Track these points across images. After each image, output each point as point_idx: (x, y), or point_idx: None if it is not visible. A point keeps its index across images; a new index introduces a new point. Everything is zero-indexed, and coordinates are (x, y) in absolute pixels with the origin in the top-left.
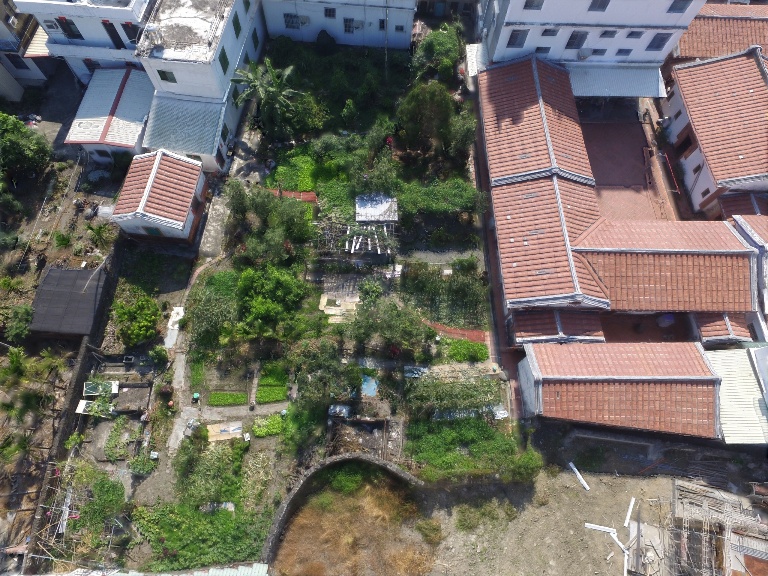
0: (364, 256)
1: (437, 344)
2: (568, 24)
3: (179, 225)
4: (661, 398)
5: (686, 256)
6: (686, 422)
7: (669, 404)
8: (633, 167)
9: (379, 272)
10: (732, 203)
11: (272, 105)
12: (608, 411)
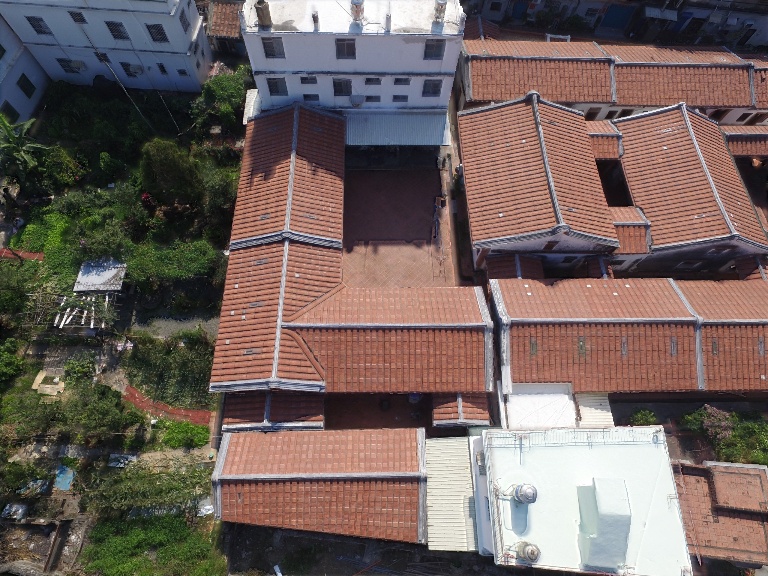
0: (78, 330)
1: (153, 428)
2: (323, 72)
3: None
4: (358, 498)
5: (414, 331)
6: (385, 525)
7: (367, 505)
8: (420, 219)
9: (110, 344)
10: (497, 264)
11: (13, 161)
12: (296, 514)
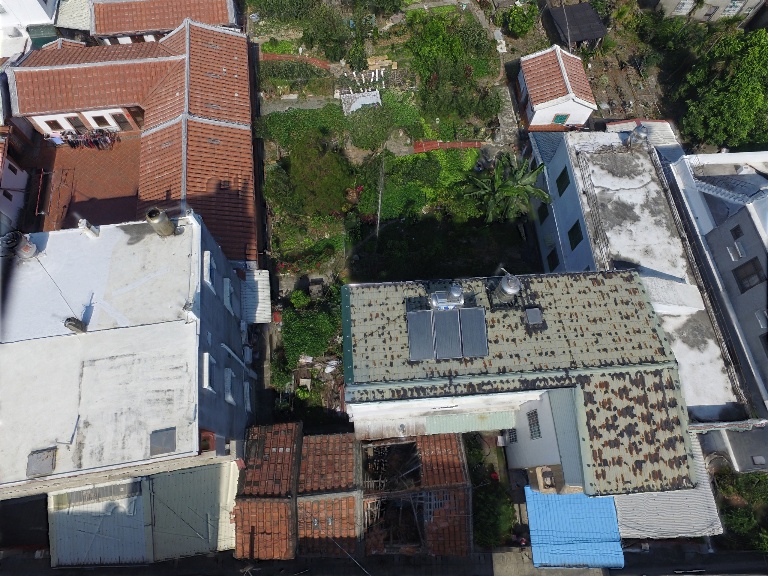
0: None
1: None
2: None
3: (524, 58)
4: None
5: None
6: None
7: None
8: None
9: None
10: None
11: None
12: None
